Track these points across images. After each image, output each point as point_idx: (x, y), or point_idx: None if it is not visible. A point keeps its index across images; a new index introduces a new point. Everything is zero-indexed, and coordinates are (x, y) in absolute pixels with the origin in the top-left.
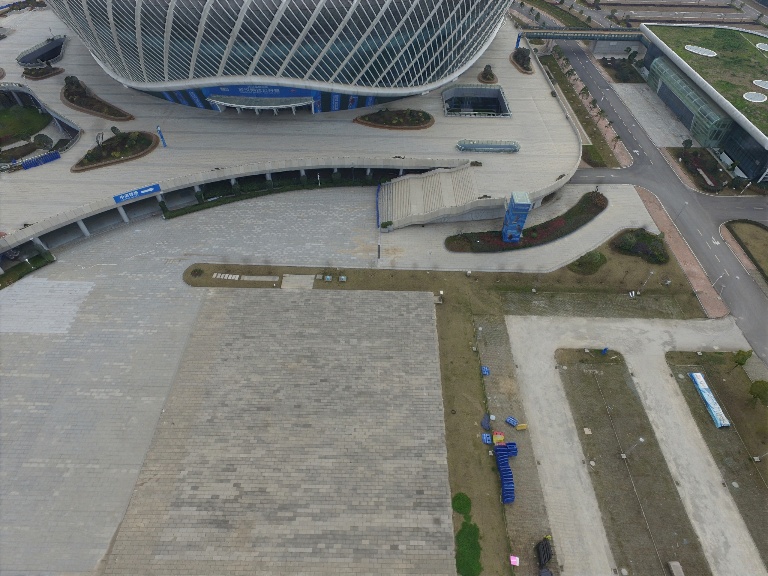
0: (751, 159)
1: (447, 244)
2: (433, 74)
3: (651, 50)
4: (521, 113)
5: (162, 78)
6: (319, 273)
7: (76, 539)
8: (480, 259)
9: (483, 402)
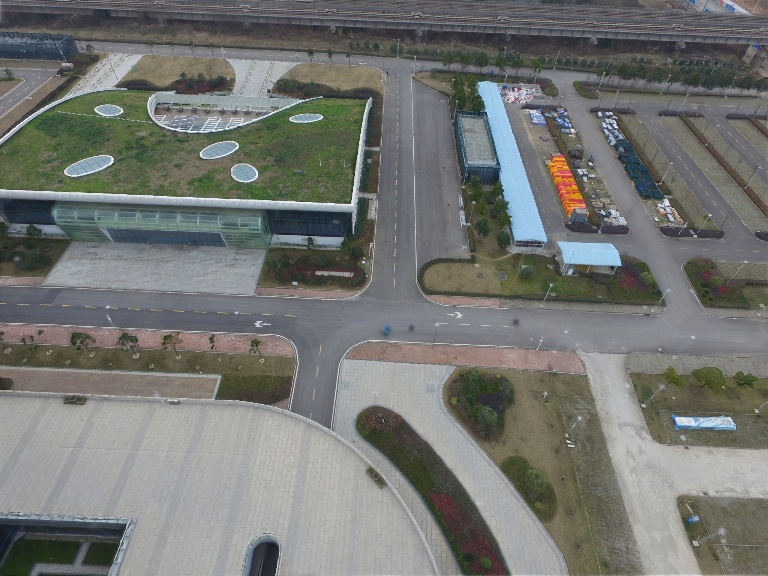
0: (324, 223)
1: None
2: None
3: (3, 203)
4: (123, 492)
5: None
6: None
7: None
8: None
9: None
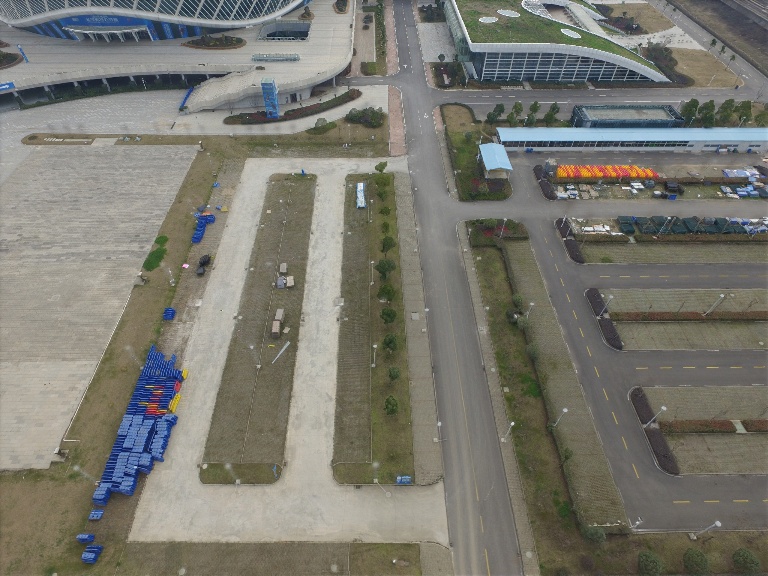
0: (479, 65)
1: (225, 120)
2: (251, 10)
3: None
4: (317, 38)
5: (28, 13)
6: (122, 137)
7: None
8: (245, 128)
9: (206, 199)
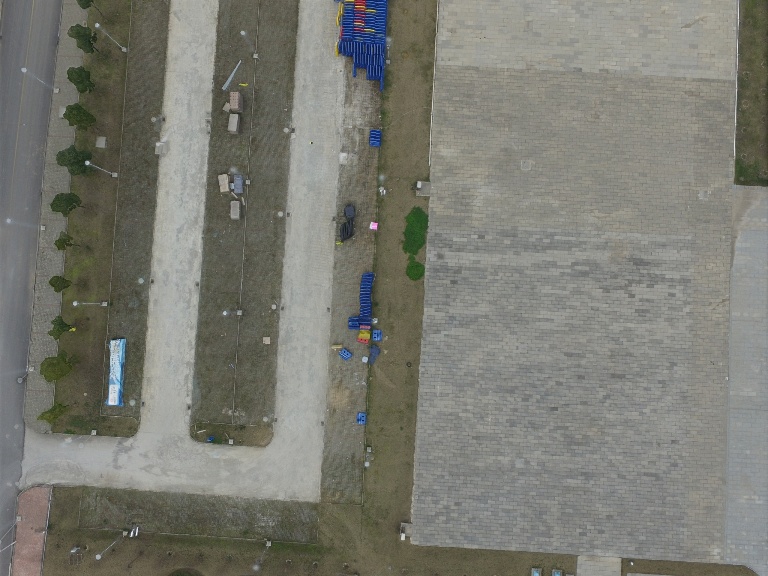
0: None
1: None
2: None
3: None
4: None
5: None
6: None
7: (767, 255)
8: None
9: (372, 378)
